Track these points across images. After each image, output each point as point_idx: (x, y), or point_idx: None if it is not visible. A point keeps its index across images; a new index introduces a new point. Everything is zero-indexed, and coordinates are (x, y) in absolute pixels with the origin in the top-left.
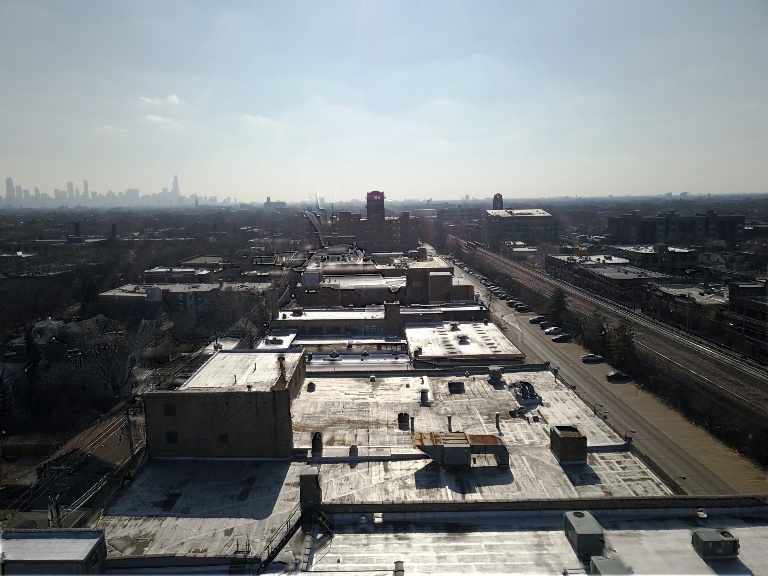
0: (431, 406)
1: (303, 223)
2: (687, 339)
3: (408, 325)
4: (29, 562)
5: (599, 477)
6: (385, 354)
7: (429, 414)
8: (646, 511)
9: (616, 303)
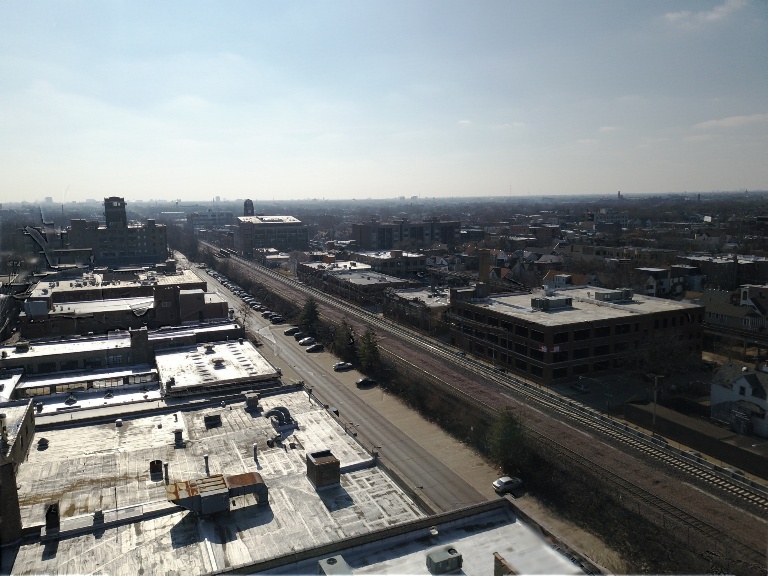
0: (187, 447)
1: (25, 241)
2: (421, 340)
3: (159, 351)
4: None
5: (352, 498)
6: (133, 393)
7: (185, 457)
8: (390, 540)
9: (362, 309)
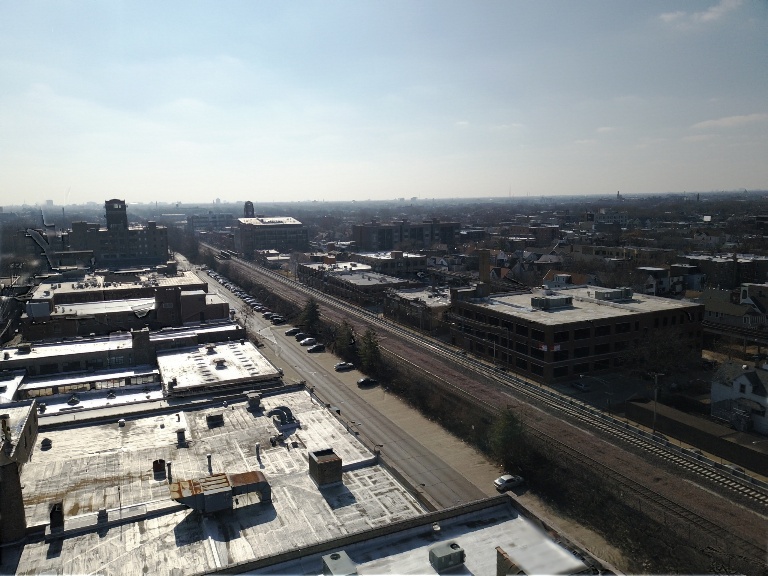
0: (189, 446)
1: (26, 243)
2: (422, 340)
3: (160, 352)
4: None
5: (354, 496)
6: (135, 394)
7: (188, 456)
8: (393, 536)
9: (363, 310)
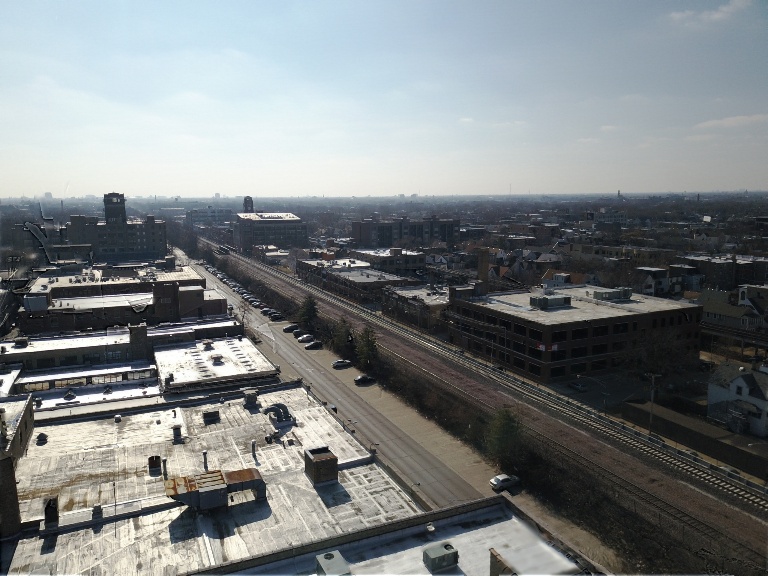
0: (185, 443)
1: (24, 237)
2: (419, 338)
3: (158, 347)
4: None
5: (349, 494)
6: (132, 389)
7: (183, 452)
8: (387, 536)
9: (361, 307)
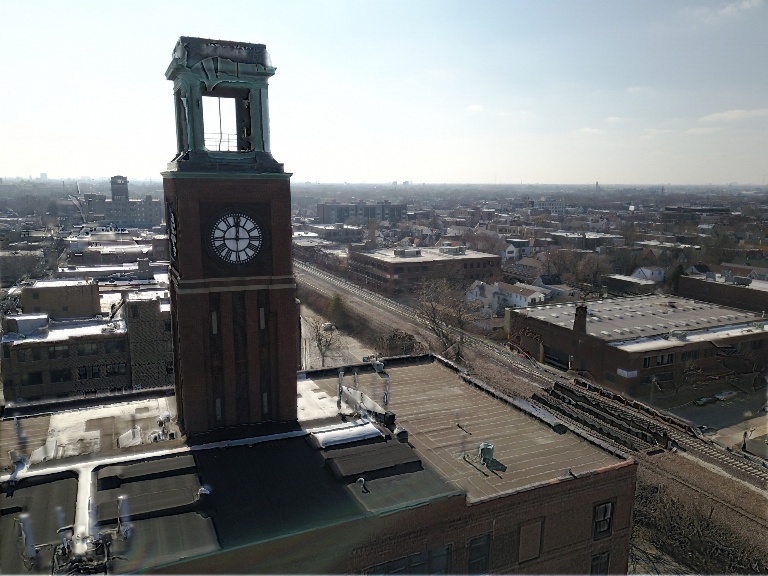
0: None
1: (68, 204)
2: None
3: (155, 273)
4: (26, 320)
5: None
6: (143, 280)
7: None
8: None
9: (298, 260)
